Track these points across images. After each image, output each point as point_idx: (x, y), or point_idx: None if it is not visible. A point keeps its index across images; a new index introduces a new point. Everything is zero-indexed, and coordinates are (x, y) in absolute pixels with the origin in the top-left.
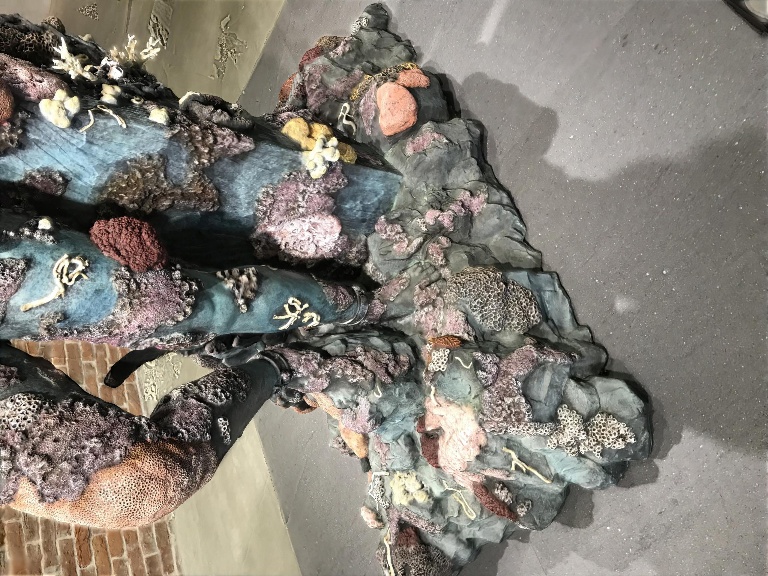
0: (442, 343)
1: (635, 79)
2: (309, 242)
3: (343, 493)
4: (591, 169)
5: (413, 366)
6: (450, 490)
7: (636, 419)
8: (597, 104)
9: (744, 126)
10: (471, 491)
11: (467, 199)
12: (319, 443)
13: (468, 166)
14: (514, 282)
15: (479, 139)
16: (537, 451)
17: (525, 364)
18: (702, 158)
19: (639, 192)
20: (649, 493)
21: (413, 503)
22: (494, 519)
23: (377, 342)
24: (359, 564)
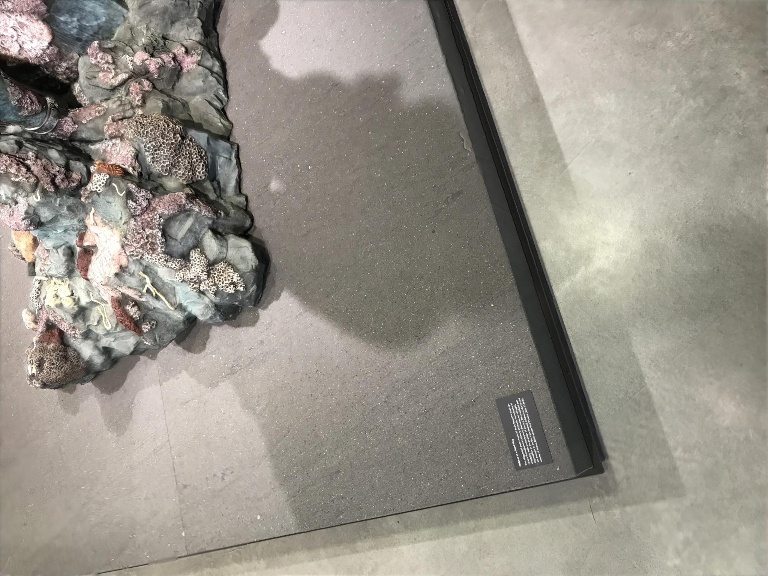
0: (105, 168)
1: (340, 1)
2: (12, 40)
3: (15, 297)
4: (288, 66)
5: (84, 185)
6: (95, 302)
7: (248, 273)
8: (309, 11)
9: (392, 70)
10: (109, 304)
11: (181, 54)
12: (5, 248)
13: (192, 25)
14: (192, 139)
15: (211, 4)
16: (168, 281)
17: (172, 206)
18: (360, 85)
19: (313, 97)
20: (248, 334)
21: (59, 306)
22: (128, 334)
23: (53, 154)
24: (14, 362)
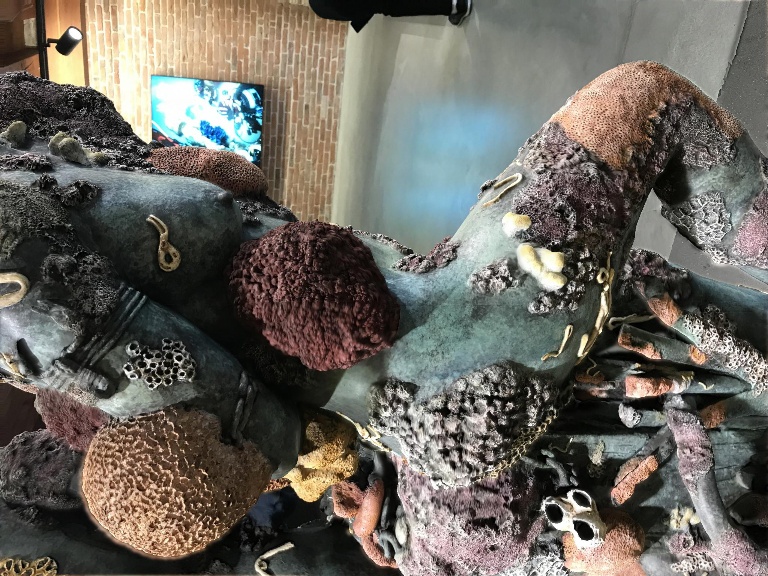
0: None
1: None
2: None
3: None
4: None
5: None
6: None
7: None
8: None
9: None
10: None
11: None
12: None
13: None
14: None
15: None
16: None
17: None
18: None
19: None
20: None
21: None
22: None
23: None
24: None
